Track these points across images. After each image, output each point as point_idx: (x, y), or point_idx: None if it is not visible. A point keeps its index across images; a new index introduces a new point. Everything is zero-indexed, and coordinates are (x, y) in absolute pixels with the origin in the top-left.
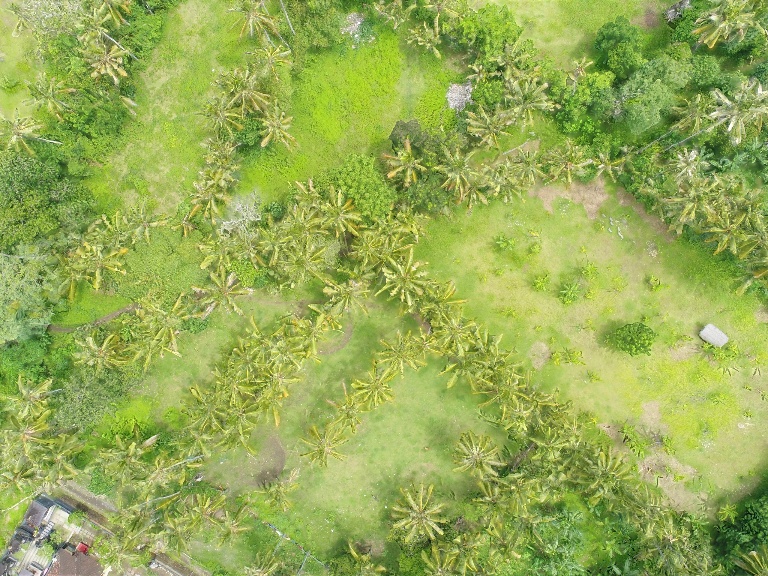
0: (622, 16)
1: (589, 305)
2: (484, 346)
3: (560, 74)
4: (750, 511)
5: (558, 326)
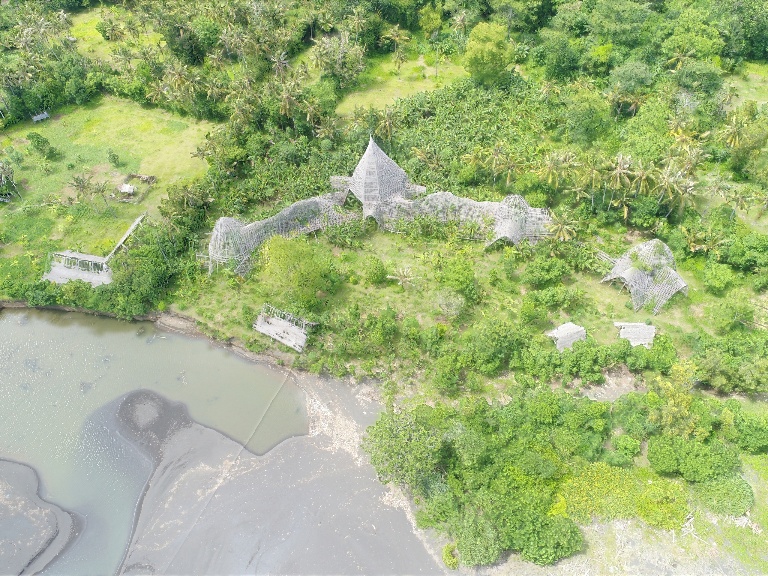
0: (72, 92)
1: (122, 44)
2: (166, 9)
3: (109, 79)
4: (76, 2)
5: (138, 39)
